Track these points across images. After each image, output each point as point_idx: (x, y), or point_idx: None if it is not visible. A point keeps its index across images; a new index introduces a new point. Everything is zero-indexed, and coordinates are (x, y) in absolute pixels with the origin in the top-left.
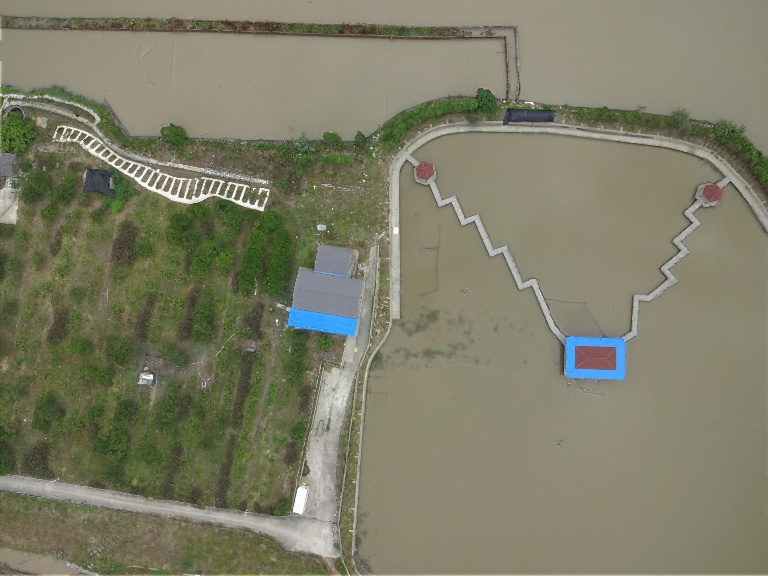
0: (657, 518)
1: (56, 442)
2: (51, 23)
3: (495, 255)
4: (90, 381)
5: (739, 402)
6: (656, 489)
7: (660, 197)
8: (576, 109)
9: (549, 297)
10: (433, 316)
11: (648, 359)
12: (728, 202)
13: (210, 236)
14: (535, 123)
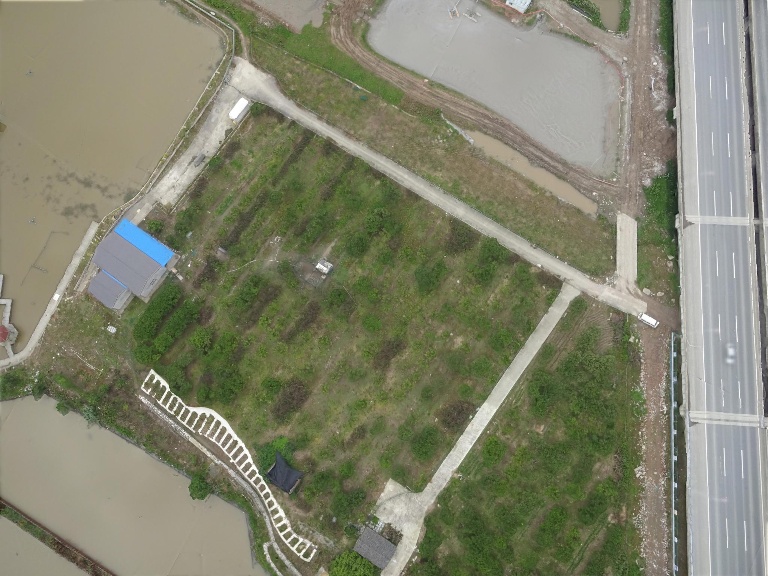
0: None
1: (436, 249)
2: None
3: None
4: None
5: None
6: None
7: None
8: None
9: None
10: (68, 212)
11: None
12: None
13: (208, 369)
14: None
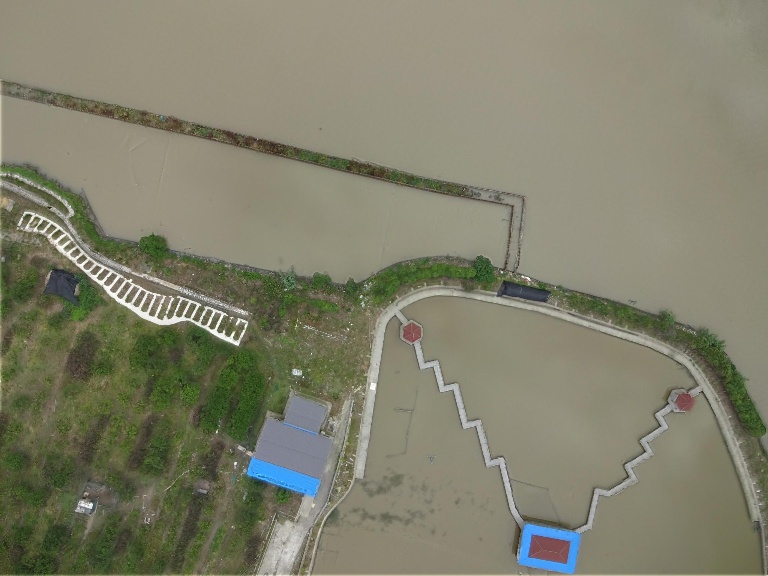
0: None
1: None
2: (34, 95)
3: (468, 428)
4: (21, 500)
5: None
6: None
7: (635, 393)
8: (570, 292)
9: (514, 478)
10: (397, 480)
11: (598, 553)
12: (697, 410)
13: (177, 364)
14: (528, 300)
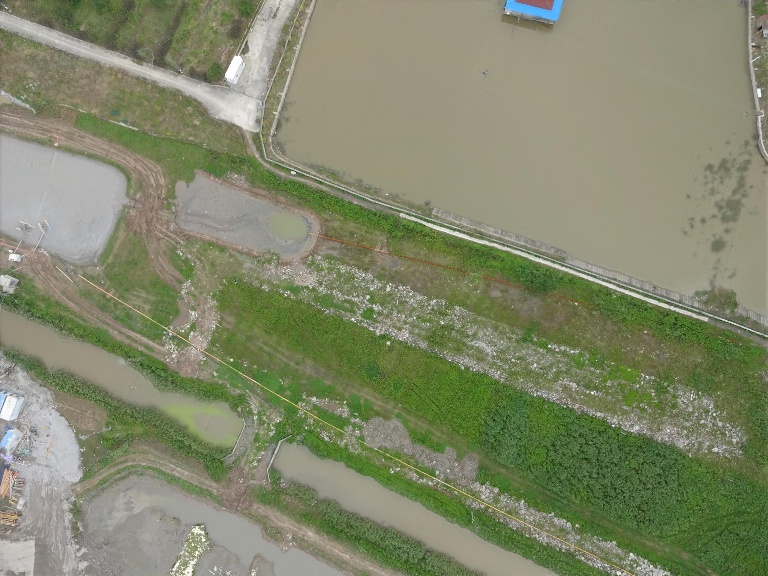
0: (557, 154)
1: None
2: None
3: None
4: None
5: (656, 60)
6: (562, 126)
7: None
8: None
9: None
10: None
11: (584, 16)
12: None
13: None
14: None
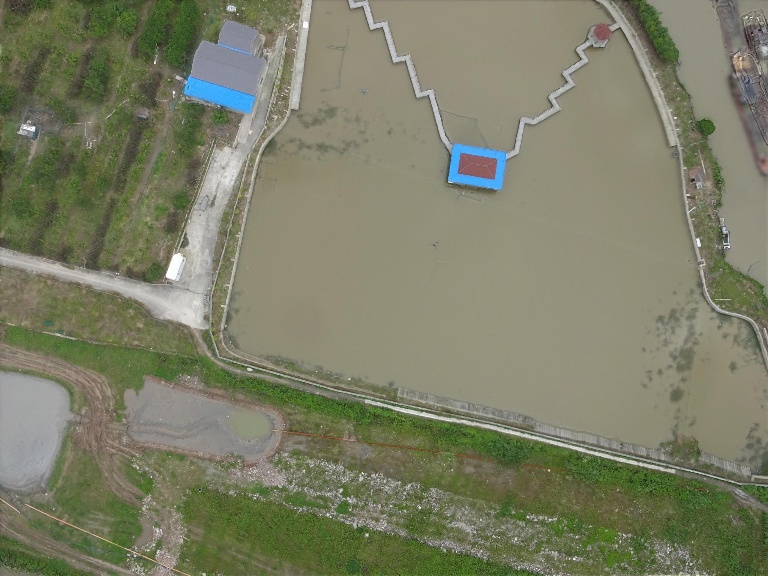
0: (514, 321)
1: None
2: None
3: (398, 62)
4: None
5: (600, 221)
6: (517, 293)
7: (557, 33)
8: None
9: (443, 109)
10: (331, 112)
11: (526, 178)
12: (615, 46)
13: None
14: None
